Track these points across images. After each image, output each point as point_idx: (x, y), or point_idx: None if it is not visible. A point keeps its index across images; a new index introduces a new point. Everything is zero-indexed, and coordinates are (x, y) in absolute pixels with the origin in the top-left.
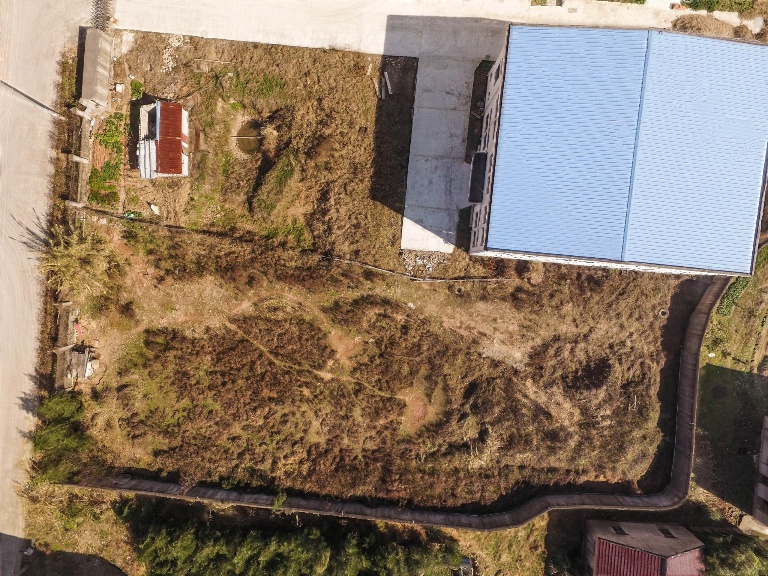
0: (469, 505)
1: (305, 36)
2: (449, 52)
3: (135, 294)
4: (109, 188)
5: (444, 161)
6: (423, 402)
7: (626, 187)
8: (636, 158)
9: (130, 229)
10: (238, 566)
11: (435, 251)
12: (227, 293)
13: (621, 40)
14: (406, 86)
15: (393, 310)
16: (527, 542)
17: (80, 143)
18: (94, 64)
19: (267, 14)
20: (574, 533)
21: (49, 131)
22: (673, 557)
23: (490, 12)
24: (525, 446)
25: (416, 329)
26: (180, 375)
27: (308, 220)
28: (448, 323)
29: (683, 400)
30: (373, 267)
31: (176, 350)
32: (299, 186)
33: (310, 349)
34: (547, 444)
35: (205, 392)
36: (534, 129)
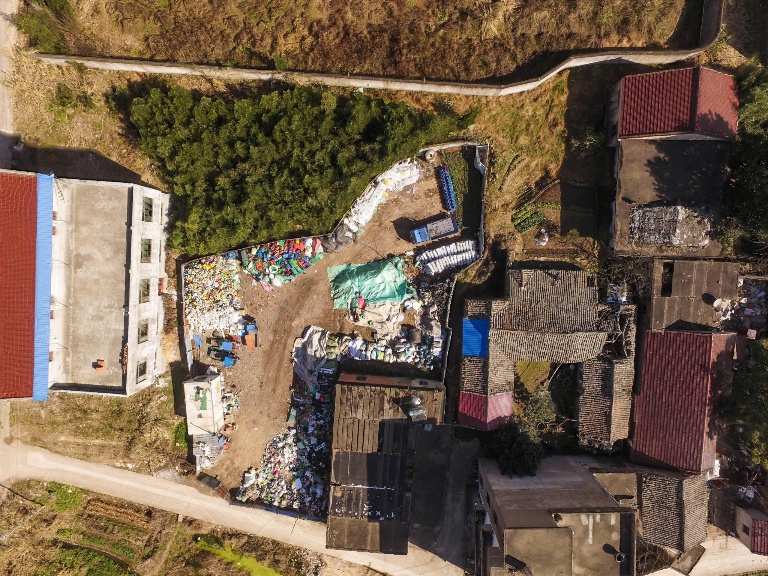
0: (483, 80)
1: None
2: None
3: None
4: None
5: None
6: None
7: None
8: None
9: None
10: (239, 123)
11: None
12: None
13: None
14: None
15: None
16: (546, 121)
17: None
18: None
19: None
20: (596, 105)
21: None
22: (706, 69)
23: None
24: (542, 2)
25: None
26: None
27: None
28: None
29: None
30: None
31: None
32: None
33: None
34: None
35: None
36: None
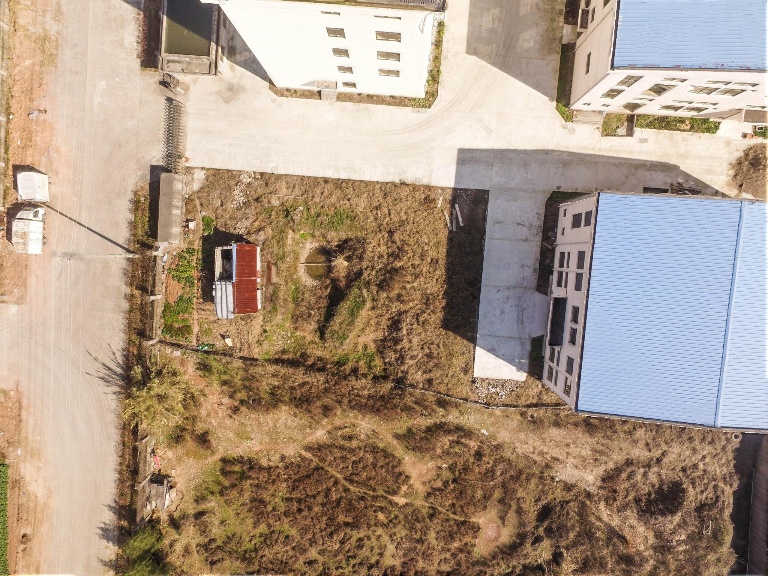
0: None
1: (376, 170)
2: (520, 184)
3: (210, 424)
4: (183, 322)
5: (516, 291)
6: (496, 524)
7: (719, 354)
8: (729, 326)
9: (204, 361)
10: None
11: (508, 379)
12: (301, 422)
13: (713, 210)
14: (477, 217)
15: (466, 437)
16: None
17: (154, 281)
18: (169, 208)
19: (337, 149)
20: None
21: (123, 268)
22: None
23: (561, 144)
24: (600, 569)
25: (489, 455)
26: (257, 503)
27: (379, 346)
28: (521, 448)
29: (757, 522)
30: (447, 396)
31: (253, 480)
32: (369, 314)
33: (385, 476)
34: (622, 567)
35: (281, 519)
36: (625, 295)
